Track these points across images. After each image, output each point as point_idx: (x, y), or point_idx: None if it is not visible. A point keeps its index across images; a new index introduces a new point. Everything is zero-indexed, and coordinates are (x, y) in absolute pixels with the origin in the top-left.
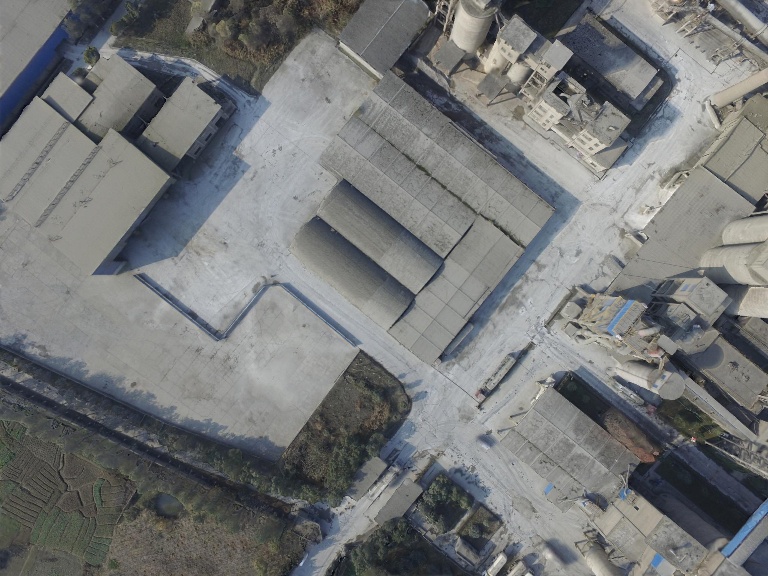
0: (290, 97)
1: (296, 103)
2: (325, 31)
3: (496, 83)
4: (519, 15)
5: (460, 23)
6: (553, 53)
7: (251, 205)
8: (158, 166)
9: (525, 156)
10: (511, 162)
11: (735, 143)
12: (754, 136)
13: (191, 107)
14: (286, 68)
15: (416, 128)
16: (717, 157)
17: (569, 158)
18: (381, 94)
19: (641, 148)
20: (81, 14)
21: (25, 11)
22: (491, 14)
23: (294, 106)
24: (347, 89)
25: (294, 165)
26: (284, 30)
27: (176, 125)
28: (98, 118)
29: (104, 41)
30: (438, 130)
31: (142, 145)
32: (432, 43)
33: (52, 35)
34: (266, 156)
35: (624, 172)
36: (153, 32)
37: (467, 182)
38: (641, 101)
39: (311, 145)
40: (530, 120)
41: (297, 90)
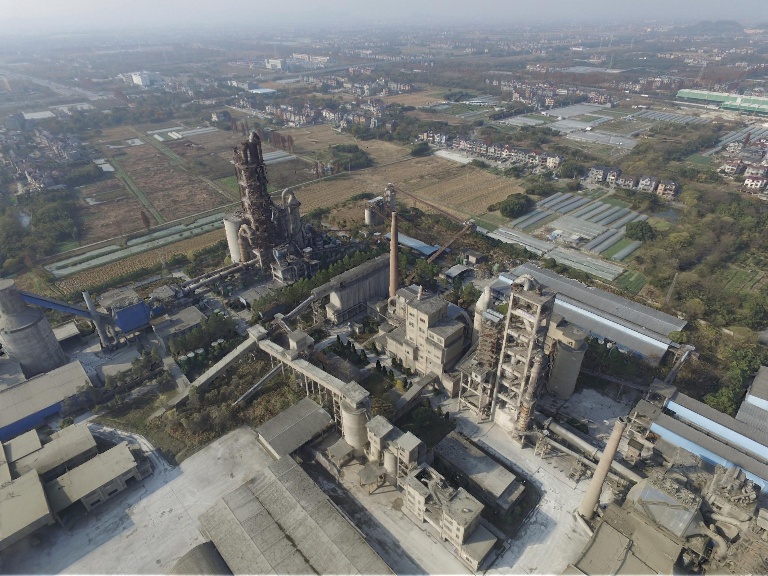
0: (202, 470)
1: (204, 475)
2: (252, 428)
3: (374, 471)
4: (404, 431)
5: (344, 421)
6: (405, 439)
7: (110, 563)
8: (47, 502)
9: (401, 545)
10: (386, 550)
11: (603, 546)
12: (620, 541)
13: (112, 462)
14: (210, 449)
15: (295, 500)
16: (588, 558)
17: (446, 552)
18: (274, 470)
19: (520, 551)
20: (81, 397)
21: (45, 392)
22: (361, 412)
23: (201, 477)
24: (252, 469)
25: (175, 528)
26: (219, 421)
27: (90, 474)
28: (32, 462)
29: (85, 418)
30: (315, 504)
31: (49, 487)
32: (332, 443)
33: (50, 407)
34: (154, 516)
35: (505, 575)
36: (125, 416)
37: (331, 558)
38: (506, 501)
39: (200, 511)
40: (408, 511)
41: (210, 465)
